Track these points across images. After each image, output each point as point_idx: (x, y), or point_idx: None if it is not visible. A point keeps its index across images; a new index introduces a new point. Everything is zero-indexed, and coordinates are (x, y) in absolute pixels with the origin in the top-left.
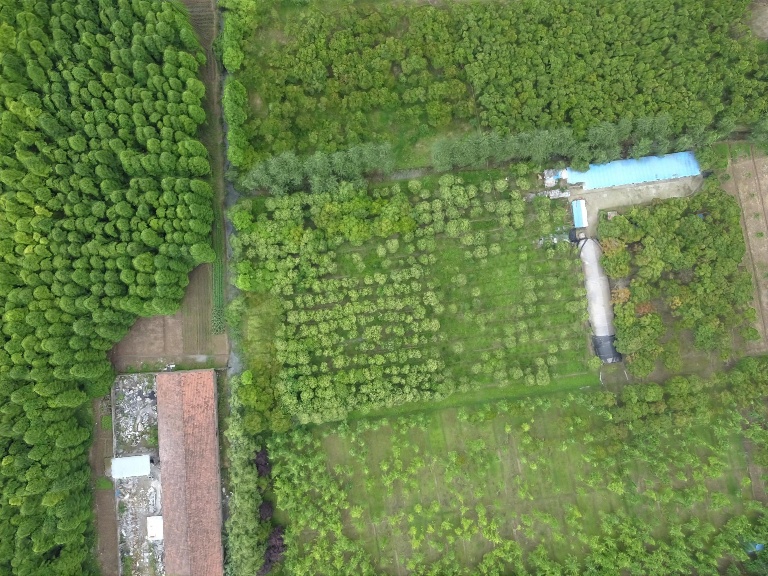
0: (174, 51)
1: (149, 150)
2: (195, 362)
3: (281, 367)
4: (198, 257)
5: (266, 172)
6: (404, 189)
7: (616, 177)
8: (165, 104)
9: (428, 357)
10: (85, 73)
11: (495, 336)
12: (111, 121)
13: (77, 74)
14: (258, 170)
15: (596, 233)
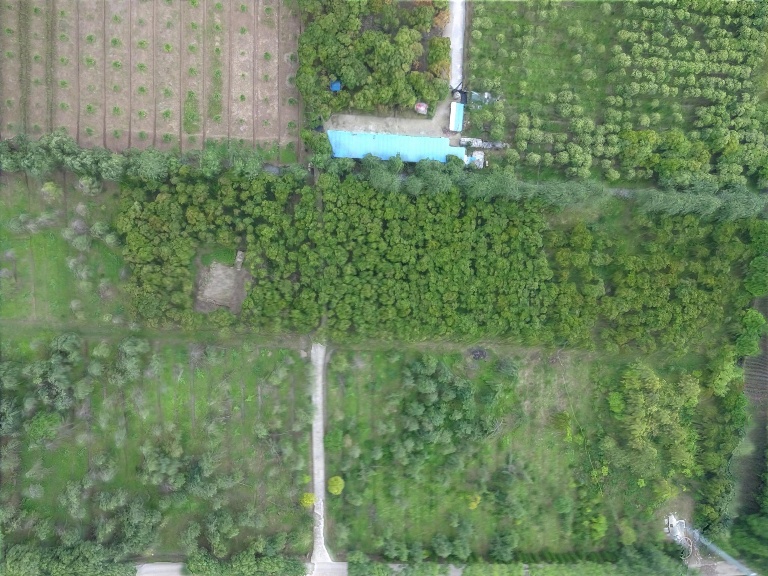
0: None
1: None
2: None
3: (764, 29)
4: None
5: None
6: None
7: (417, 145)
8: None
9: (634, 6)
10: None
11: (566, 13)
12: None
13: None
14: (762, 206)
15: None
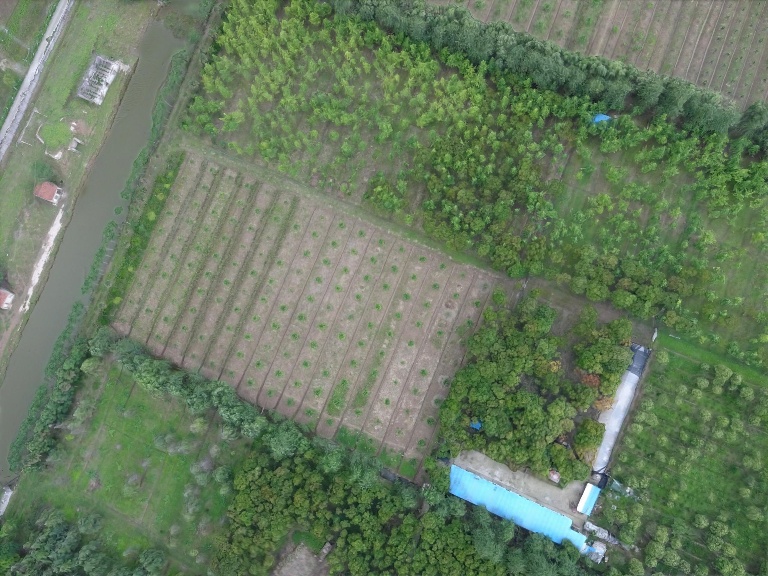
0: None
1: None
2: None
3: None
4: None
5: None
6: None
7: (536, 513)
8: None
9: None
10: None
11: None
12: None
13: None
14: None
15: None
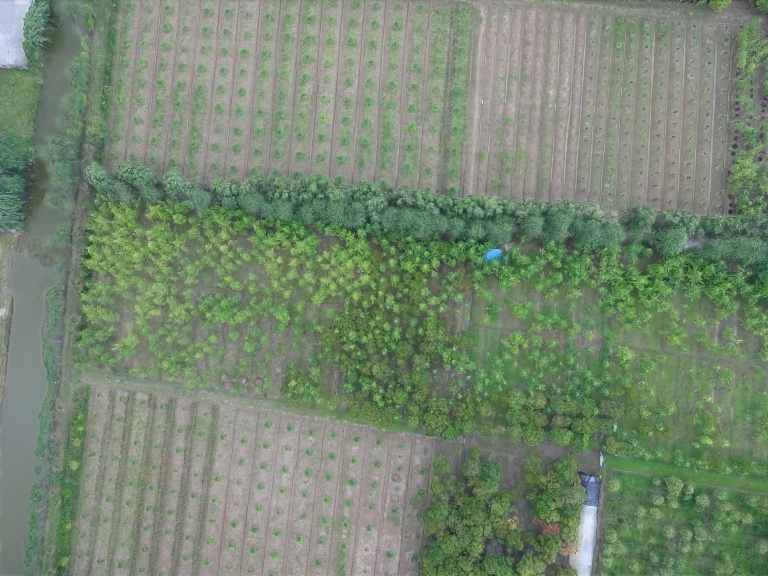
0: None
1: None
2: None
3: None
4: None
5: None
6: None
7: None
8: None
9: None
10: None
11: (713, 544)
12: None
13: None
14: None
15: None
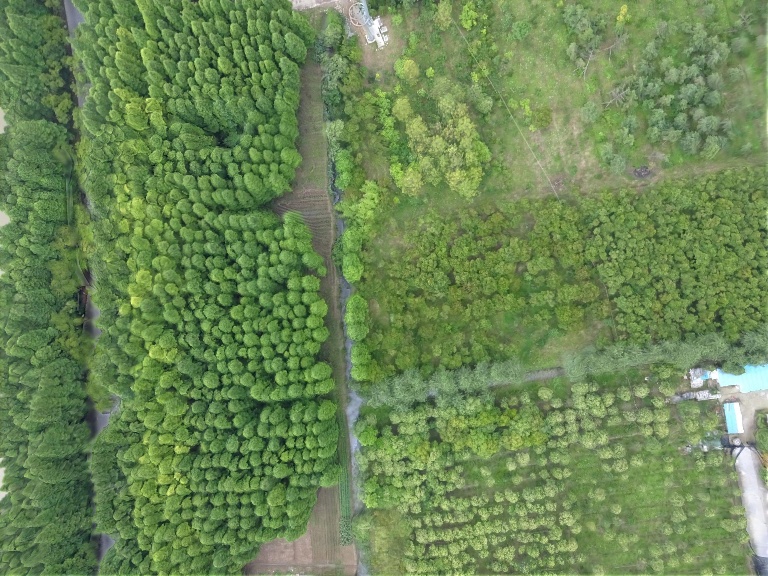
0: (297, 277)
1: (277, 383)
2: (324, 572)
3: None
4: (327, 486)
5: (391, 394)
6: (533, 395)
7: None
8: (290, 331)
9: None
10: (215, 311)
11: (639, 556)
12: (241, 356)
13: (208, 315)
14: (383, 392)
15: (753, 439)
